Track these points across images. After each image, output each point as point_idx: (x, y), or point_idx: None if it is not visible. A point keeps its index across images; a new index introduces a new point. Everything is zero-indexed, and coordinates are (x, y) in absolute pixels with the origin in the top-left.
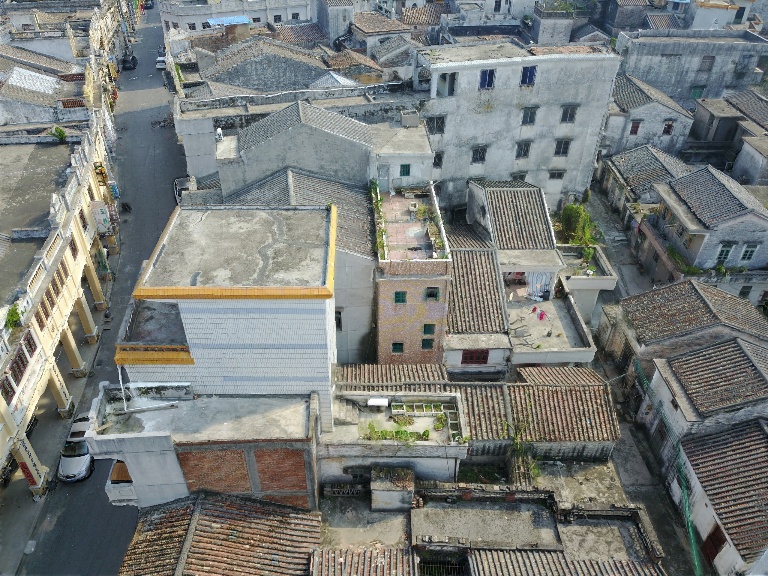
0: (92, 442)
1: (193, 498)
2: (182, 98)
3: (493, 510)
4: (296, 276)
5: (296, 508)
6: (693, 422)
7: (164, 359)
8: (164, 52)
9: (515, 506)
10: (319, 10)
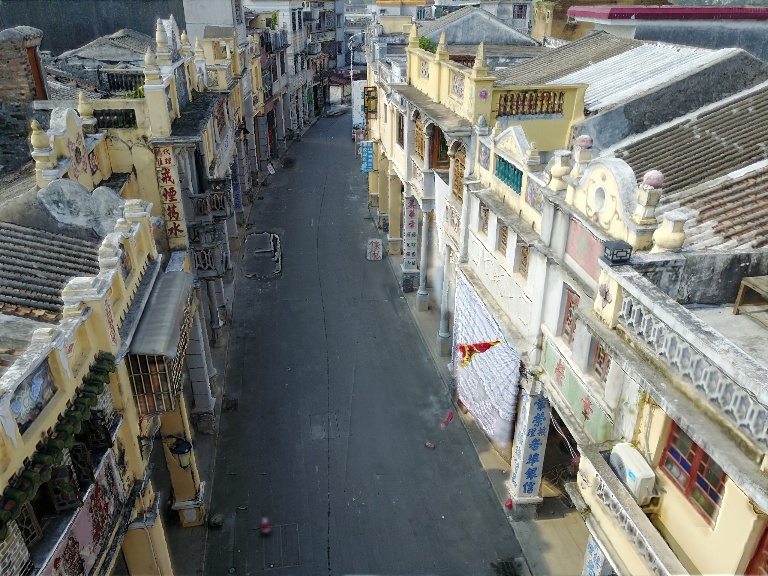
0: None
1: None
2: None
3: None
4: None
5: None
6: None
7: None
8: None
9: None
10: None
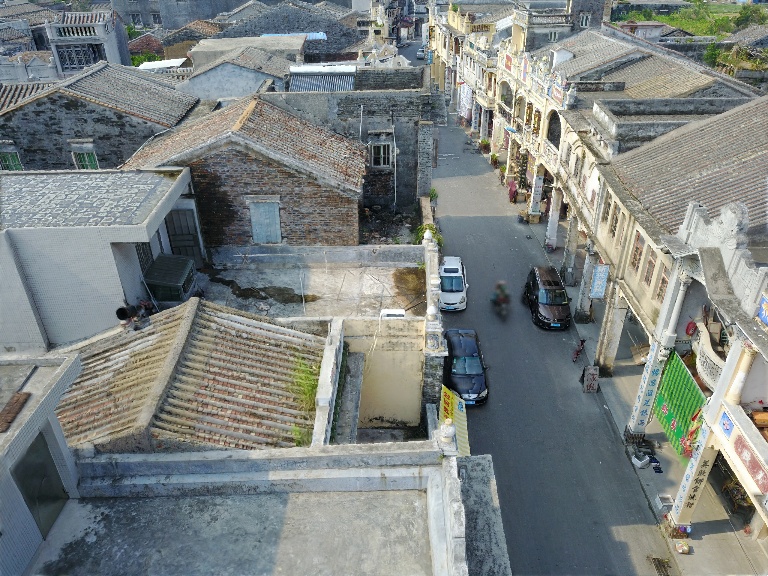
0: None
1: None
2: (373, 2)
3: None
4: None
5: None
6: None
7: None
8: (458, 332)
9: None
10: (120, 46)
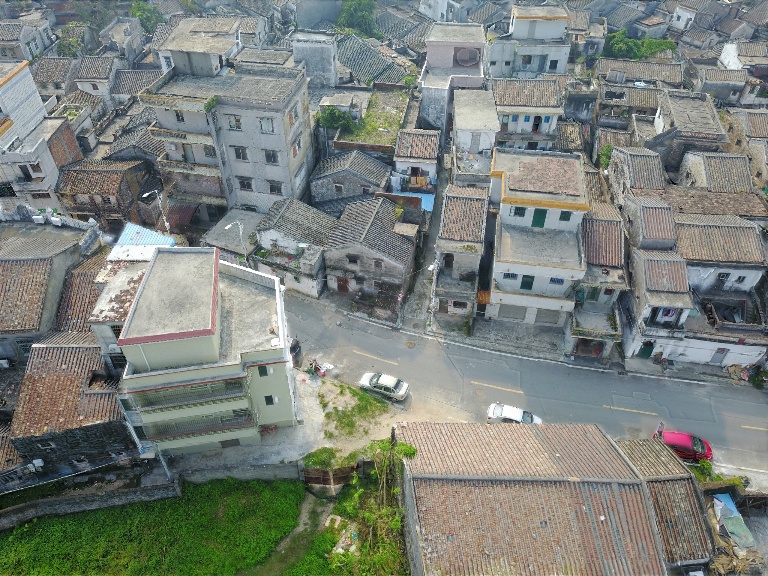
0: (32, 154)
1: (61, 172)
2: None
3: (112, 126)
4: (10, 67)
5: (81, 160)
6: (108, 82)
7: (6, 127)
8: None
9: (113, 122)
10: None
